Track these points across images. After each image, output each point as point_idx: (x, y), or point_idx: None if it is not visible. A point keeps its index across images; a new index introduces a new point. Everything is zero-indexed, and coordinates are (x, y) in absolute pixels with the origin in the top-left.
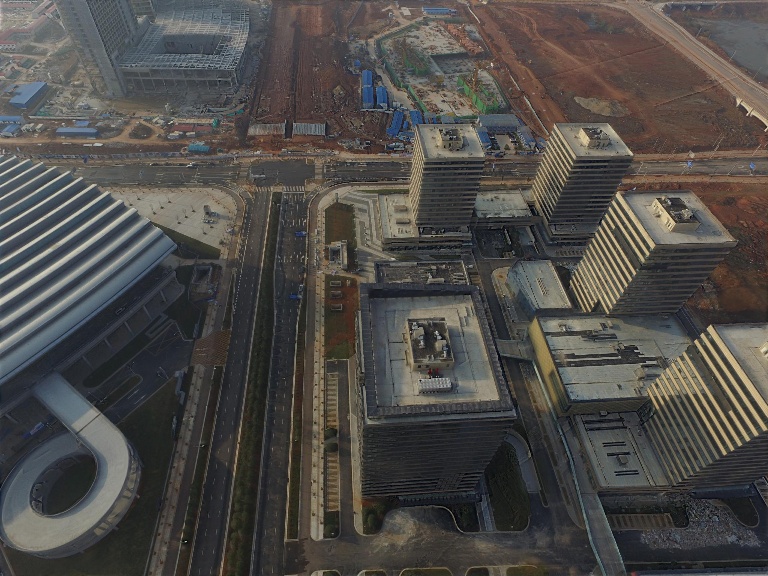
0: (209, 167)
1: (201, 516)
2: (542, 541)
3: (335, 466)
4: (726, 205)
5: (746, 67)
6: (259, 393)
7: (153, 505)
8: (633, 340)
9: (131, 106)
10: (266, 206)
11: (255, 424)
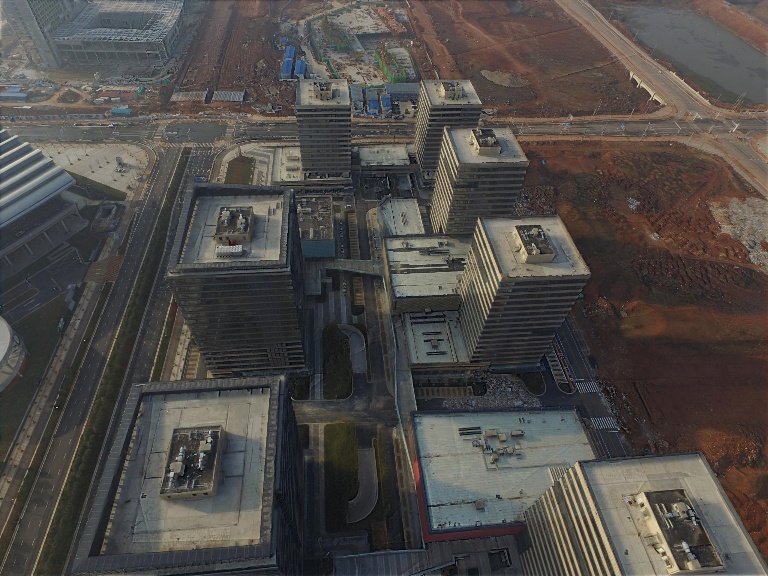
0: (129, 127)
1: (74, 390)
2: (359, 406)
3: (196, 355)
4: (591, 158)
5: (650, 47)
6: (139, 300)
7: (33, 382)
8: (463, 254)
9: (64, 76)
10: (175, 159)
11: (131, 323)
